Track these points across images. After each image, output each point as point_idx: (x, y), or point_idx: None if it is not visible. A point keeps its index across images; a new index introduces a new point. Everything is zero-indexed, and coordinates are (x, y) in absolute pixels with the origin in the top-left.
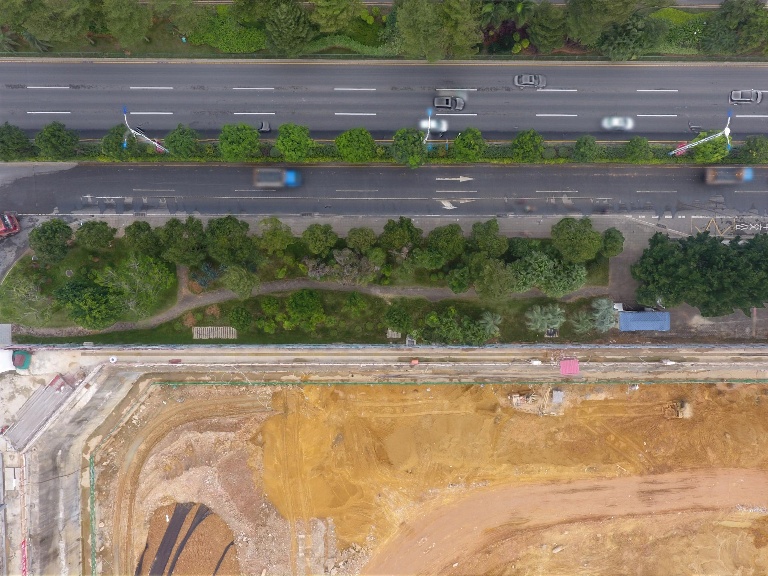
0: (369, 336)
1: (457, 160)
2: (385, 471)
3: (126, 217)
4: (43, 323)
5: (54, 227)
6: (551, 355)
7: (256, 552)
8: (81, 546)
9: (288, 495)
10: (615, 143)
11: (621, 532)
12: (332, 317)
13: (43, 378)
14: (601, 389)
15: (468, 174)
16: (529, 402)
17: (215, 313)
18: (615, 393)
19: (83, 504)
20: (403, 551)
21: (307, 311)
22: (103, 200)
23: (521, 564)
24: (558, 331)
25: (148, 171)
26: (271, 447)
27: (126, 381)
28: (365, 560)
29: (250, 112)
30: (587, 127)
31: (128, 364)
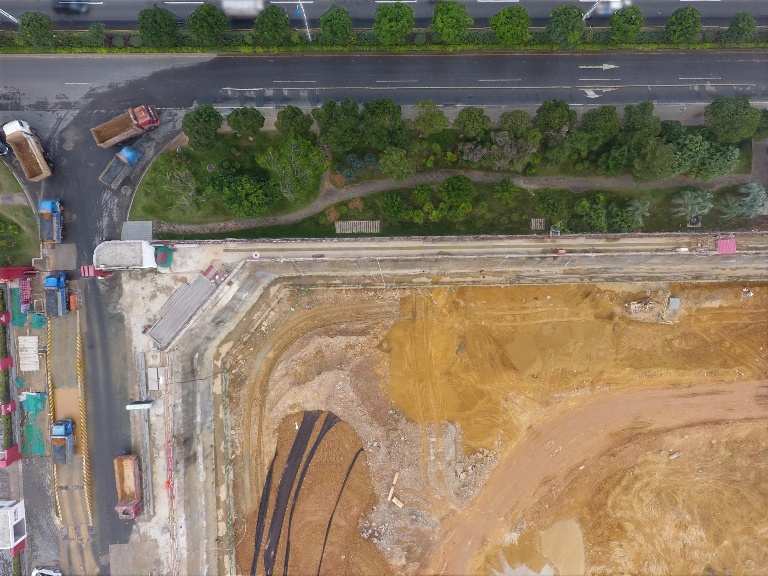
0: (513, 228)
1: (602, 46)
2: (511, 376)
3: (266, 110)
4: (197, 211)
5: (208, 111)
6: (698, 242)
7: (388, 456)
8: (214, 453)
9: (419, 399)
10: (759, 28)
11: (735, 439)
12: (485, 203)
13: (185, 276)
14: (716, 296)
15: (611, 62)
16: (646, 310)
17: (358, 207)
18: (729, 300)
19: (215, 411)
20: (531, 454)
21: (463, 195)
22: (243, 93)
23: (640, 470)
24: (701, 220)
25: (288, 62)
26: (400, 352)
27: (260, 283)
28: (494, 463)
29: (391, 0)
30: (731, 12)
31: (272, 259)
